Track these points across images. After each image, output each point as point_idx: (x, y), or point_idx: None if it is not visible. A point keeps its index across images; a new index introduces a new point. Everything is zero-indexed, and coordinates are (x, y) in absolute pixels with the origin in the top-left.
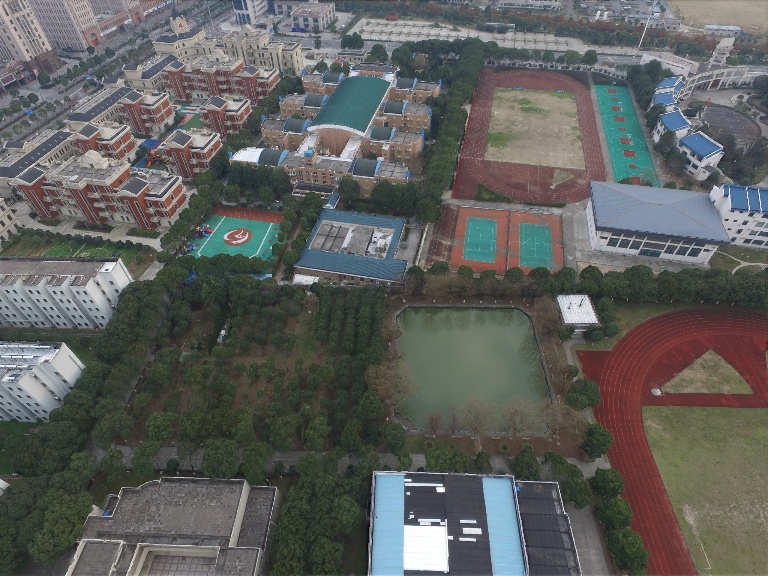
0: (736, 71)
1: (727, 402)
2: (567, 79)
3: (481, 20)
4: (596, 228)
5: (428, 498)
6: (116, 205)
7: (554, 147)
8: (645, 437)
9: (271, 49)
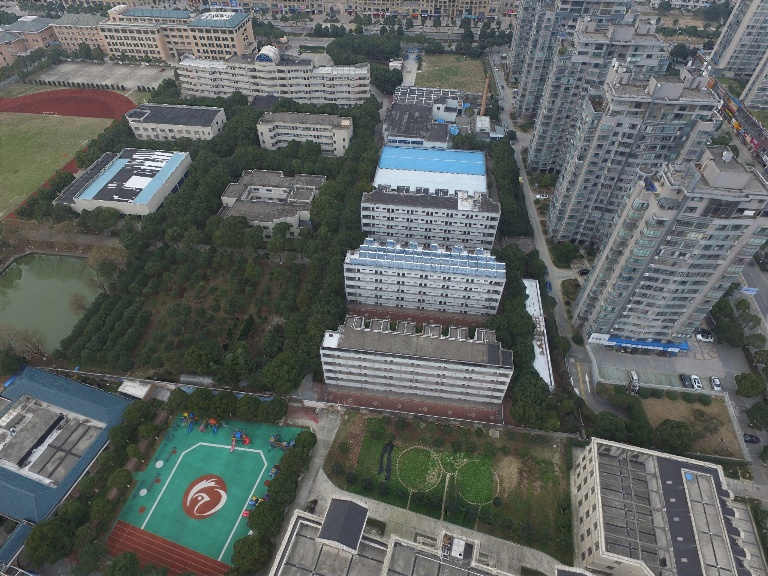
0: None
1: None
2: None
3: None
4: None
5: (125, 195)
6: None
7: None
8: None
9: None
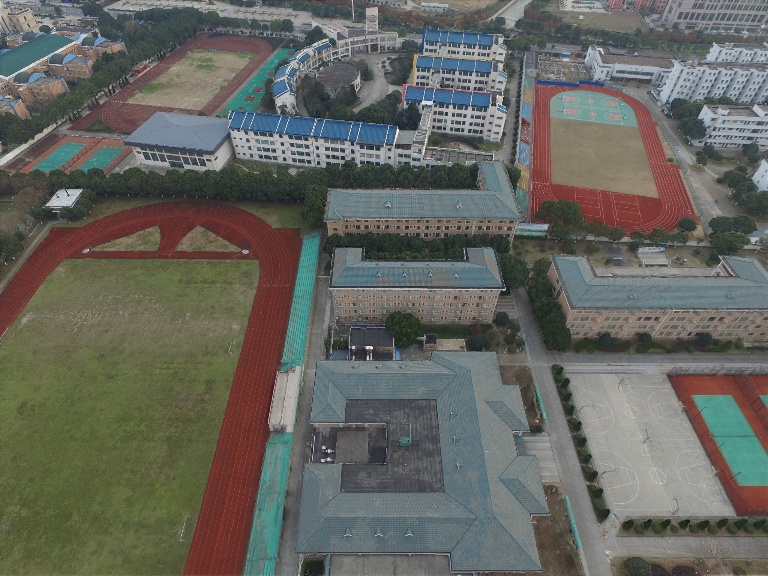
0: (388, 37)
1: (130, 256)
2: (263, 44)
3: None
4: (124, 143)
5: None
6: None
7: (192, 94)
8: (46, 276)
9: None
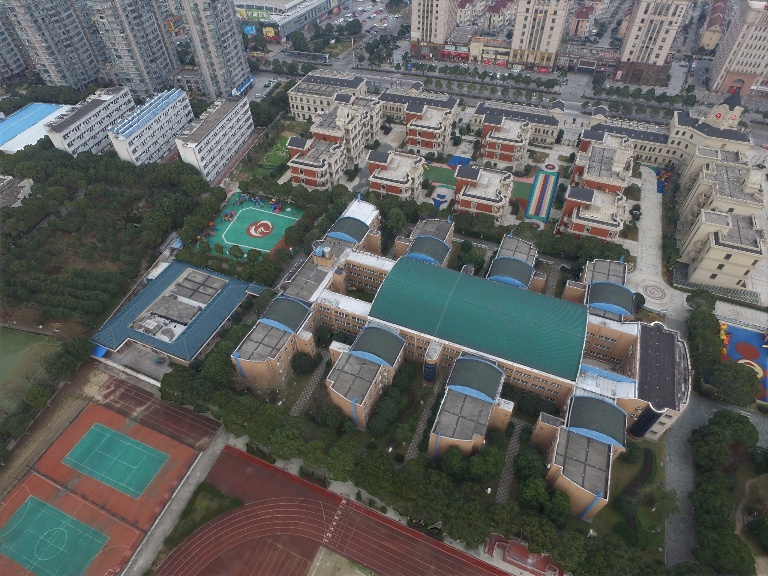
0: None
1: None
2: None
3: None
4: None
5: None
6: None
7: None
8: None
9: None
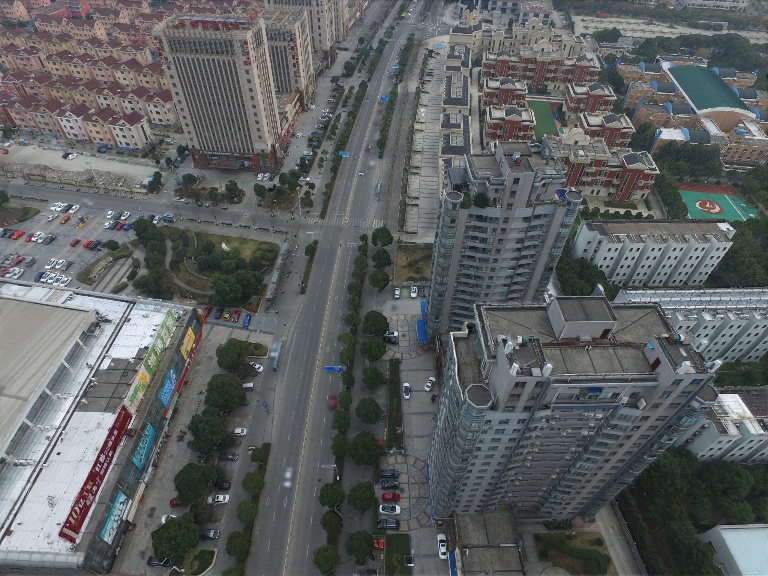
0: None
1: None
2: None
3: (695, 18)
4: None
5: None
6: (598, 179)
7: None
8: None
9: (567, 41)
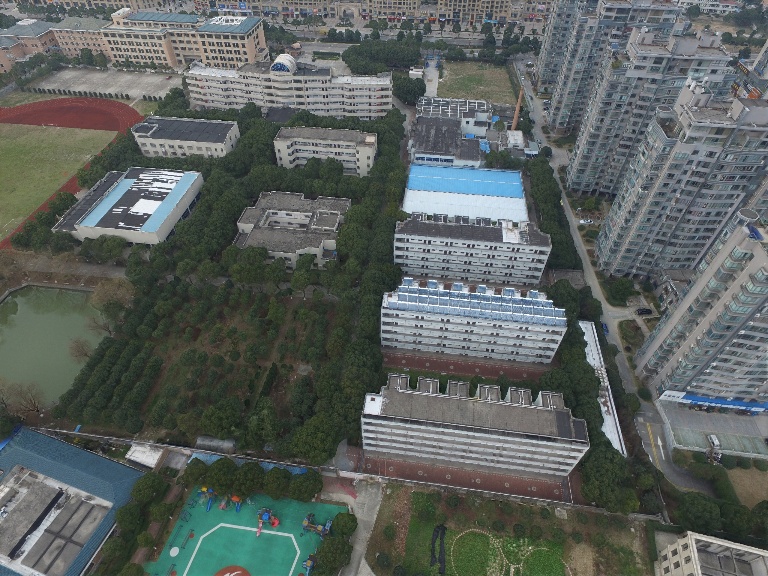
0: None
1: None
2: None
3: None
4: None
5: (131, 221)
6: None
7: None
8: None
9: None
